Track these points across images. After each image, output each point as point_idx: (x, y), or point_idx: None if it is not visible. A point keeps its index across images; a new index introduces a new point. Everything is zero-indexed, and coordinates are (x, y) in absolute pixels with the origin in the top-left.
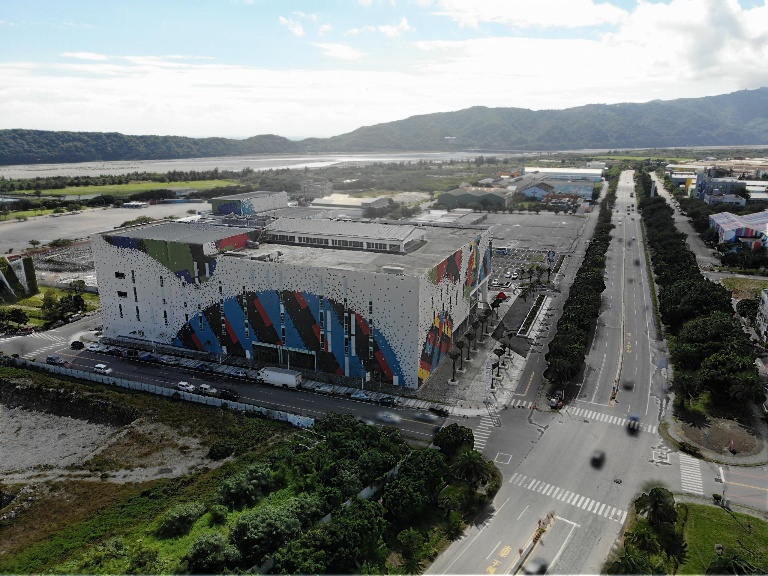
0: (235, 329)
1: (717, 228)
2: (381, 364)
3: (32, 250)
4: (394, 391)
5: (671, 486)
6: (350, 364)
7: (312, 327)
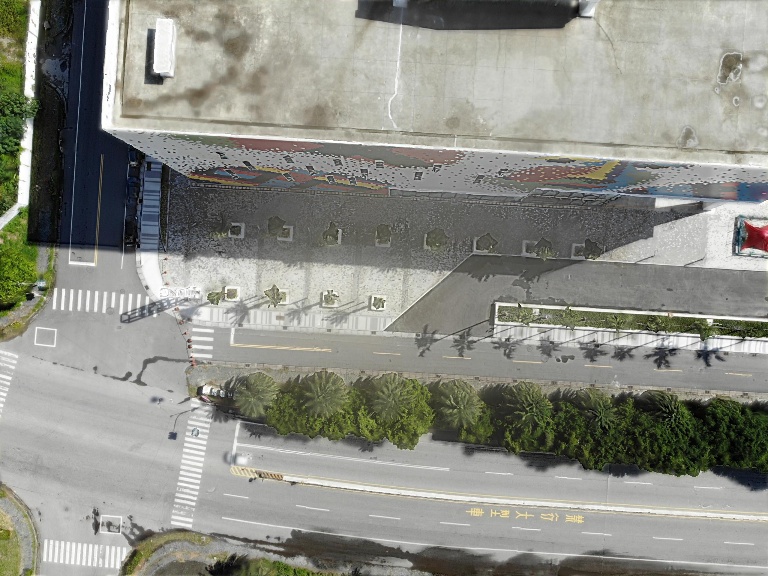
0: None
1: None
2: None
3: None
4: None
5: (48, 528)
6: None
7: None
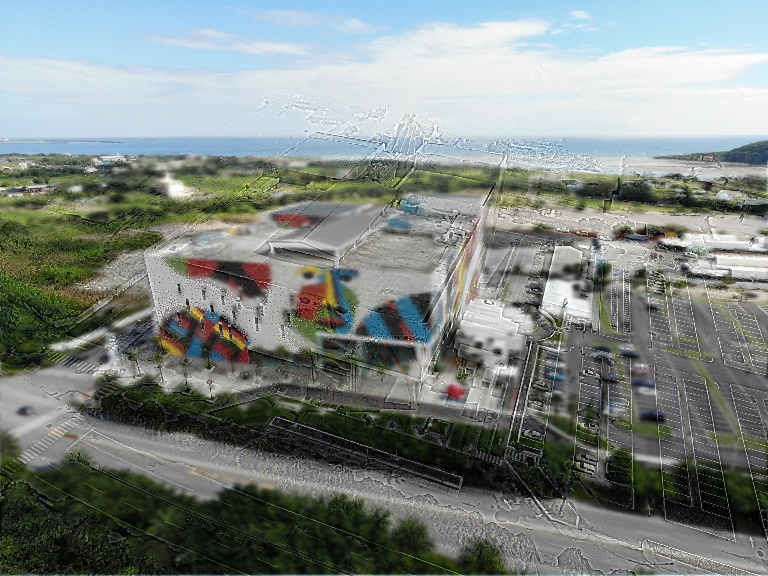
0: None
1: None
2: None
3: (553, 137)
4: None
5: None
6: None
7: None
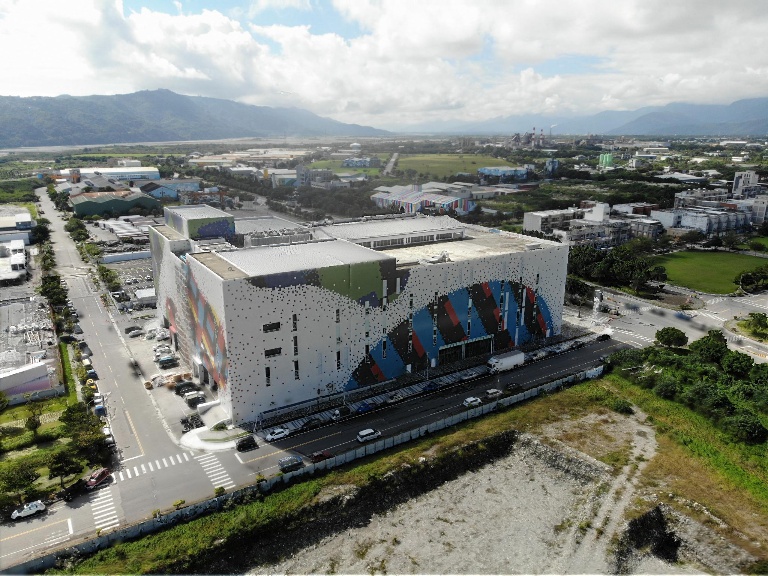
0: (422, 341)
1: (396, 203)
2: (540, 324)
3: None
4: (558, 340)
5: None
6: (519, 334)
7: (494, 312)
